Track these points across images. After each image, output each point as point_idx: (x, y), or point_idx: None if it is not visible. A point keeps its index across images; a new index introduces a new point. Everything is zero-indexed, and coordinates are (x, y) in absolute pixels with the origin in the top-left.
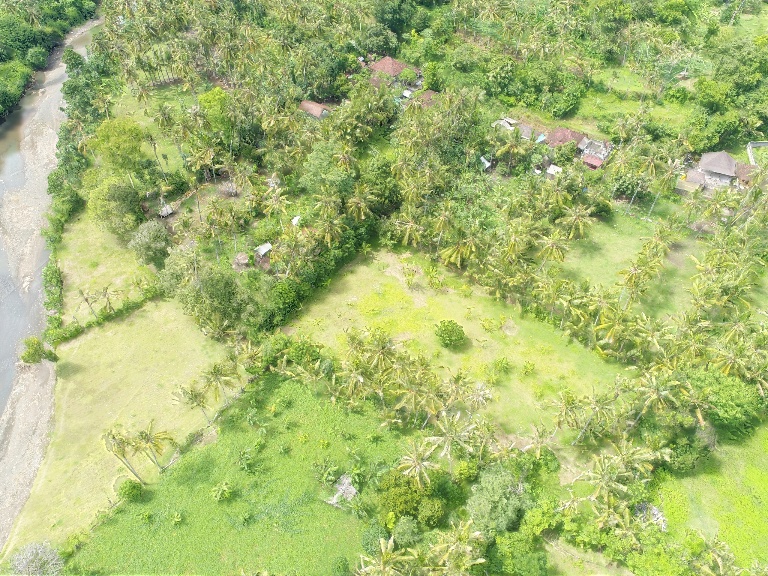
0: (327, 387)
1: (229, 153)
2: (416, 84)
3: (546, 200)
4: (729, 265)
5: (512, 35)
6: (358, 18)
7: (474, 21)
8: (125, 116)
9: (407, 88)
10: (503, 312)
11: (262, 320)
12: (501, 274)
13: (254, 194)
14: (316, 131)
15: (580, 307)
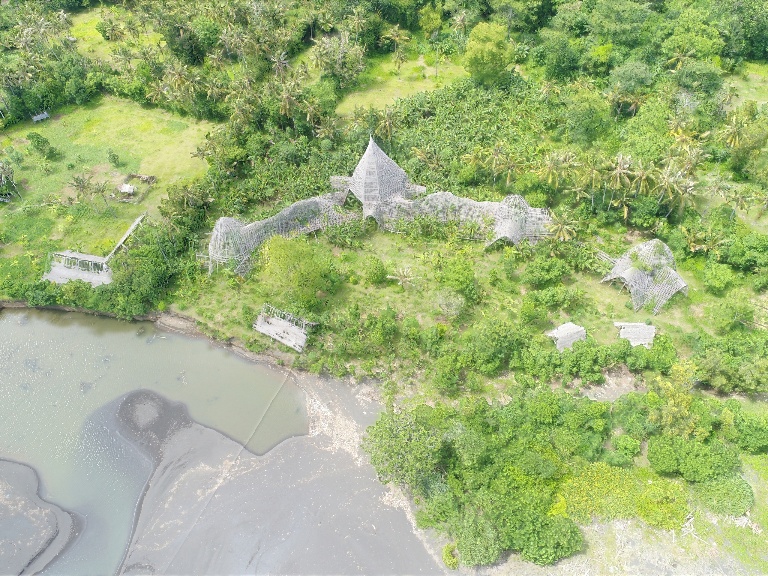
0: None
1: None
2: None
3: None
4: None
5: None
6: None
7: None
8: None
9: None
10: (149, 27)
11: (2, 25)
12: (142, 1)
13: None
14: None
15: (170, 9)
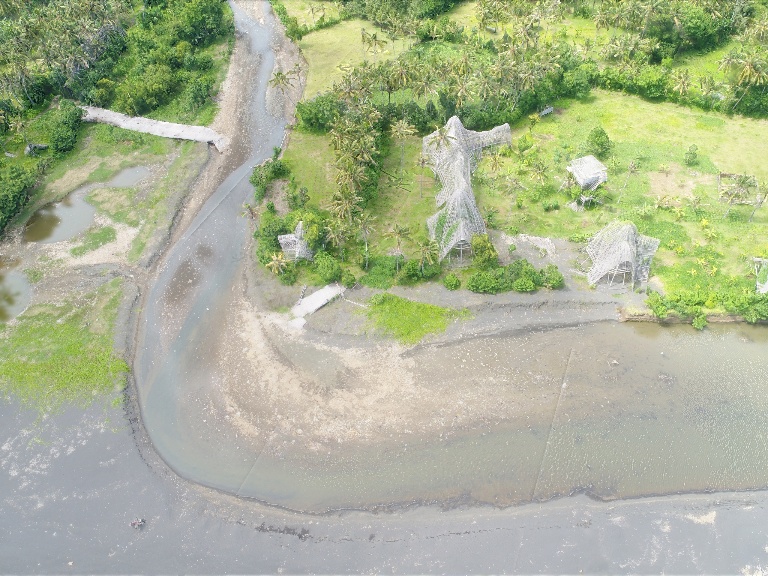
0: None
1: None
2: None
3: None
4: None
5: None
6: None
7: None
8: None
9: None
10: None
11: (419, 13)
12: None
13: None
14: None
15: None
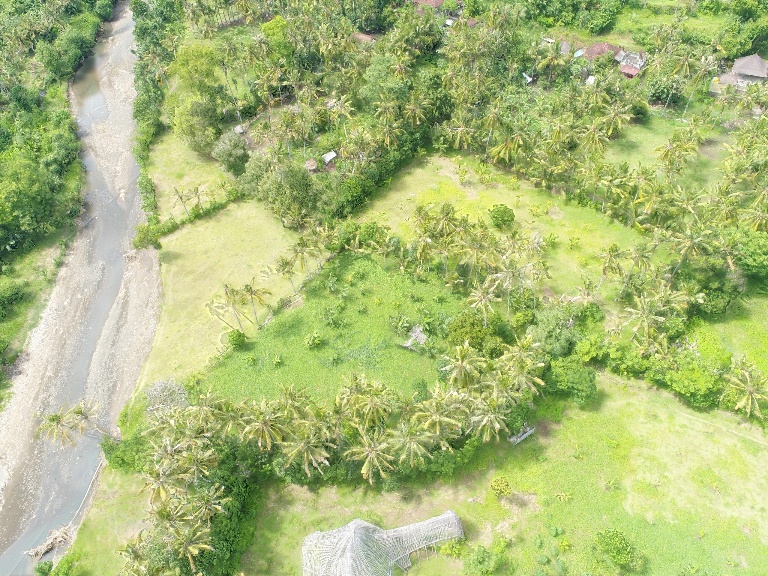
0: (395, 263)
1: None
2: (457, 14)
3: (586, 100)
4: (759, 147)
5: None
6: None
7: None
8: None
9: (449, 17)
10: None
11: (335, 208)
12: (547, 164)
13: (317, 110)
14: (371, 50)
15: (620, 187)
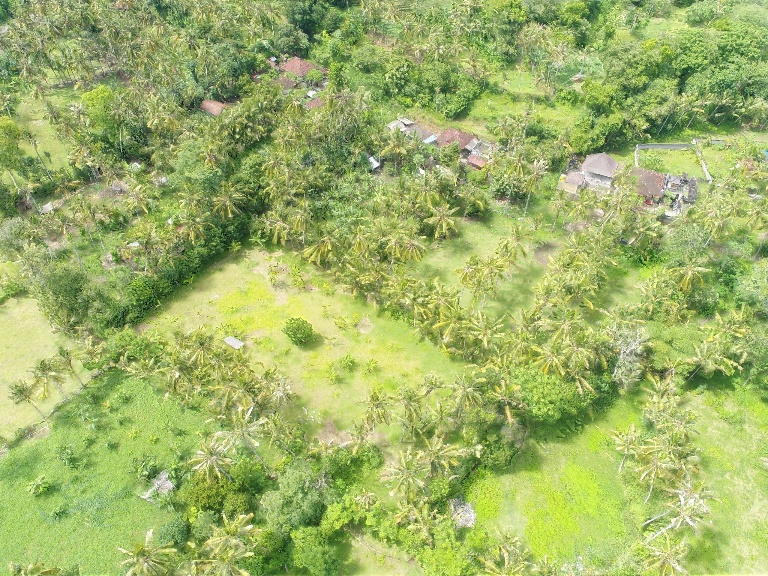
0: None
1: (99, 151)
2: (323, 84)
3: (413, 200)
4: (579, 265)
5: (412, 36)
6: (269, 18)
7: (385, 22)
8: (29, 114)
9: (313, 88)
10: (361, 310)
11: (110, 317)
12: (356, 272)
13: None
14: (194, 130)
15: (424, 305)
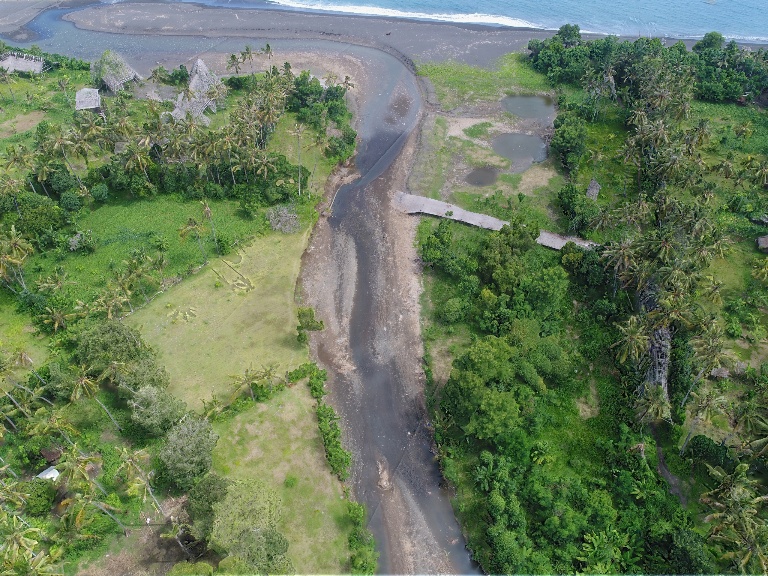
0: None
1: None
2: None
3: None
4: None
5: None
6: None
7: None
8: None
9: None
10: None
11: None
12: None
13: (6, 562)
14: None
15: None
